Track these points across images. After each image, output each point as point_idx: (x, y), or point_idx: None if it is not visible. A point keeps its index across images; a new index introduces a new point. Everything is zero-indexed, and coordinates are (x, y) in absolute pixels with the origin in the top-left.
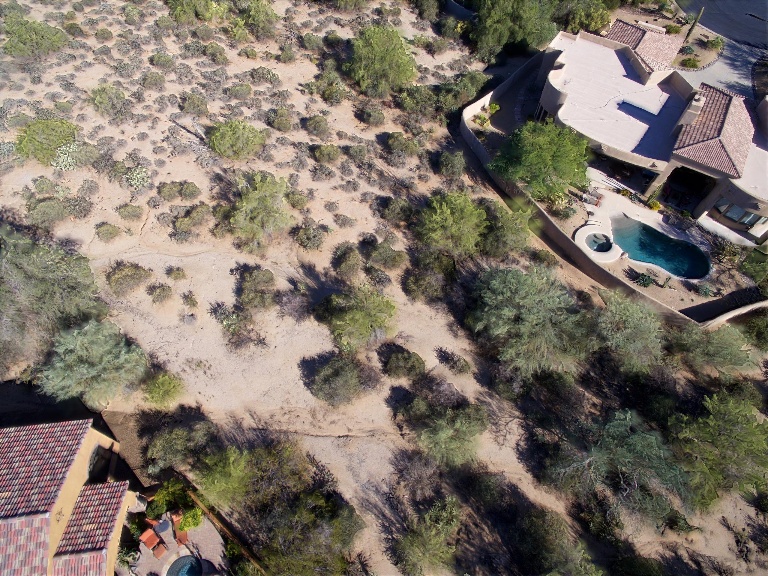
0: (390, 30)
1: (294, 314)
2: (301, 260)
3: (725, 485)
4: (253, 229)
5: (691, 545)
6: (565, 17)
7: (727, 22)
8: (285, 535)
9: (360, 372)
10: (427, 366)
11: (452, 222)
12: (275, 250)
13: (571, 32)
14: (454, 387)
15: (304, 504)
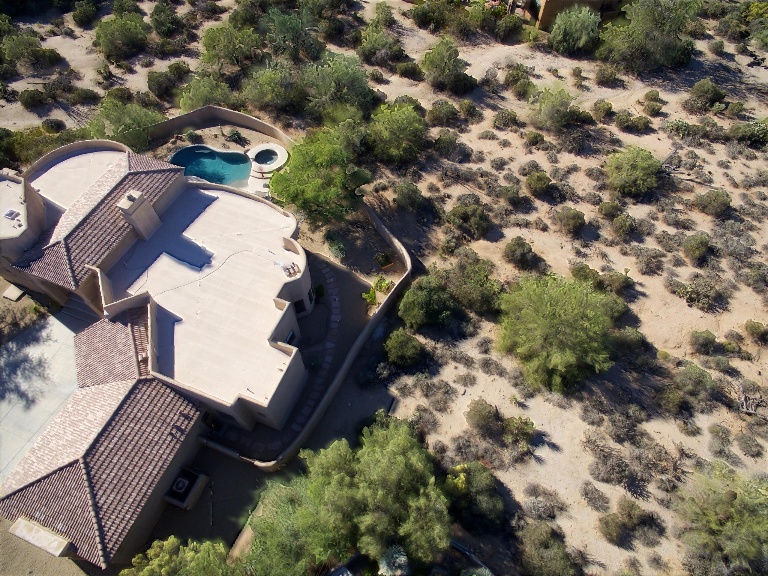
0: None
1: None
2: None
3: None
4: None
5: None
6: None
7: None
8: (443, 2)
9: None
10: None
11: None
12: None
13: (219, 547)
14: (379, 54)
15: None
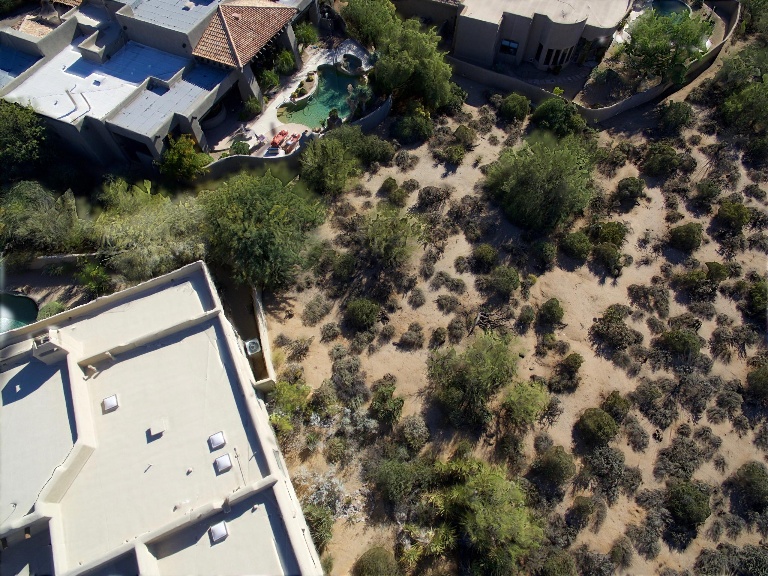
0: None
1: None
2: None
3: None
4: None
5: None
6: None
7: None
8: None
9: None
10: None
11: None
12: None
13: None
14: None
15: None
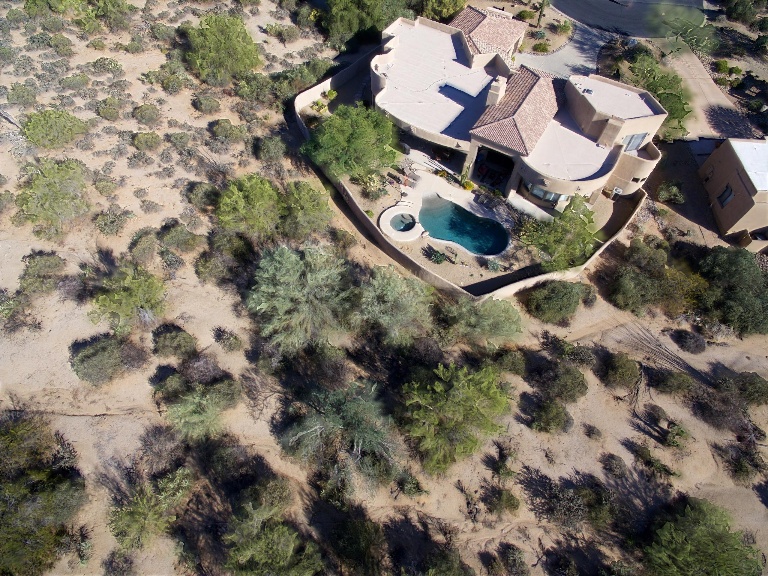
0: (246, 19)
1: (73, 298)
2: (99, 246)
3: (463, 450)
4: (47, 216)
5: (423, 508)
6: (421, 4)
7: (584, 7)
8: None
9: (120, 352)
10: (201, 345)
11: (244, 204)
12: (75, 237)
13: None
14: (211, 364)
15: (25, 480)
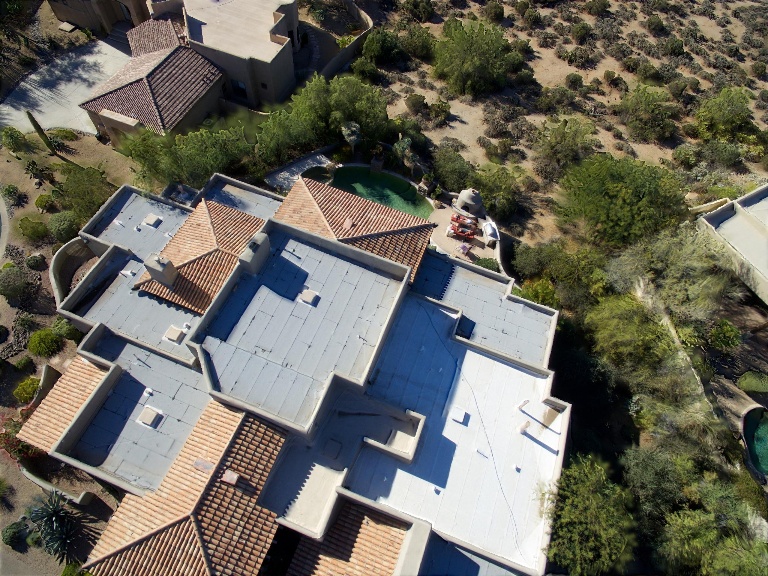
0: None
1: None
2: None
3: None
4: None
5: None
6: None
7: None
8: None
9: None
10: None
11: None
12: None
13: None
14: None
15: None
